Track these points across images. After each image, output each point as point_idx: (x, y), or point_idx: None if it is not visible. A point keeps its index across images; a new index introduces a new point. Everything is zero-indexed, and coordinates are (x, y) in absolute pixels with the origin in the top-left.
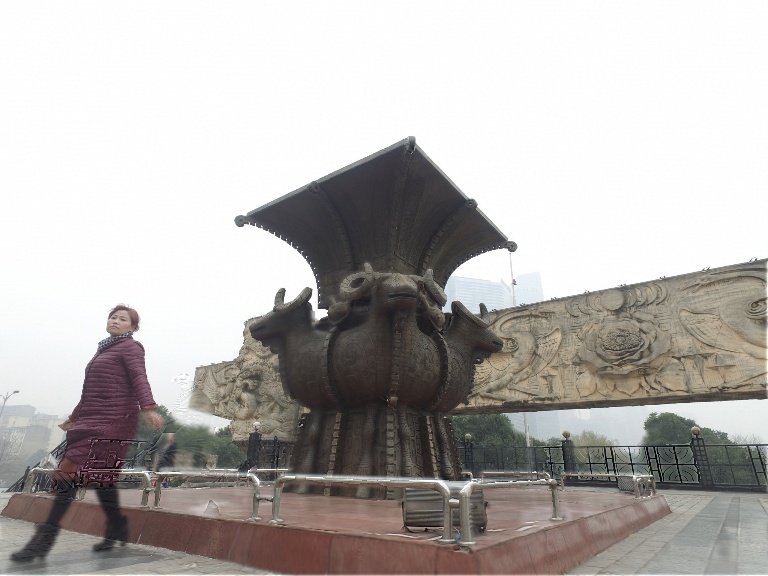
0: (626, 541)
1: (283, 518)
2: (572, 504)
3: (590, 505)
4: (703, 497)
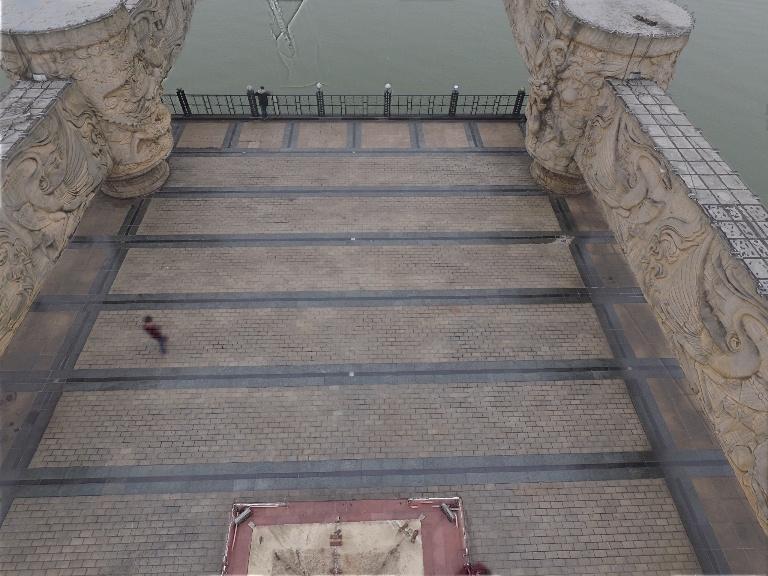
0: (366, 498)
1: (458, 564)
2: (347, 518)
3: (347, 511)
4: (39, 506)
